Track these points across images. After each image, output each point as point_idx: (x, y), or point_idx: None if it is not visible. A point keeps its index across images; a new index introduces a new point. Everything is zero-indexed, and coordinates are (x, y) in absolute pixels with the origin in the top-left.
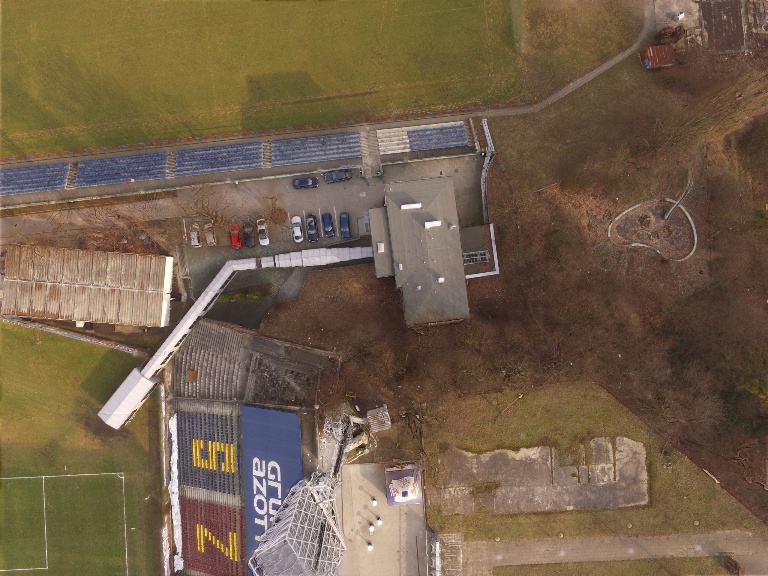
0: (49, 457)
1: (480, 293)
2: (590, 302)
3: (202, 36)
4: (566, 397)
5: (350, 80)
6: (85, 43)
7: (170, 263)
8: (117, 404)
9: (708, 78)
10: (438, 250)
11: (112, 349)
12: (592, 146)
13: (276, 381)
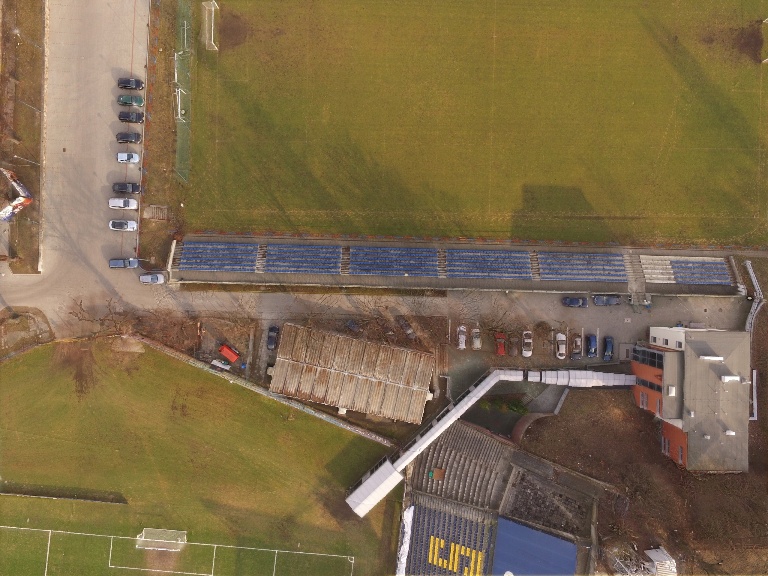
0: (285, 532)
1: None
2: None
3: (486, 141)
4: None
5: (621, 203)
6: (373, 132)
7: None
8: (367, 494)
9: None
10: (729, 402)
11: (360, 435)
12: None
13: (542, 501)
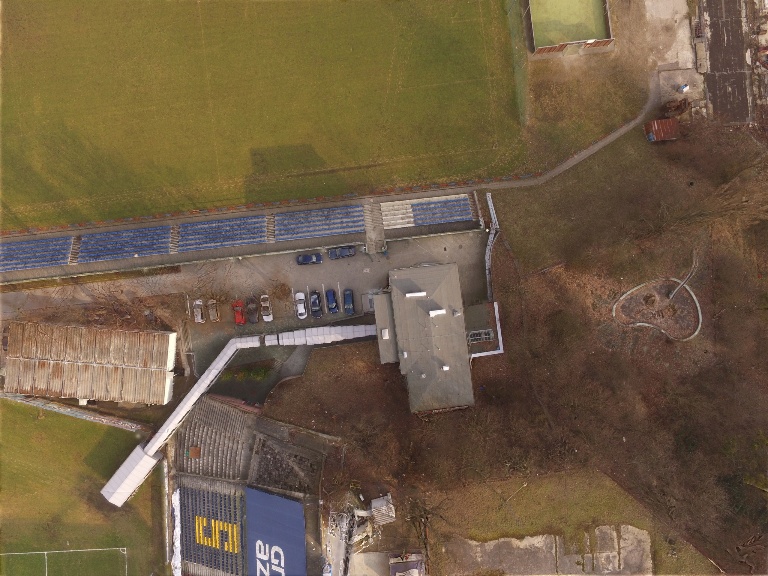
0: (51, 532)
1: (484, 372)
2: (595, 386)
3: (206, 109)
4: (571, 485)
5: (354, 153)
6: (88, 116)
7: (173, 339)
8: (120, 482)
9: (713, 152)
10: (443, 337)
11: None
12: (597, 224)
13: (280, 464)
